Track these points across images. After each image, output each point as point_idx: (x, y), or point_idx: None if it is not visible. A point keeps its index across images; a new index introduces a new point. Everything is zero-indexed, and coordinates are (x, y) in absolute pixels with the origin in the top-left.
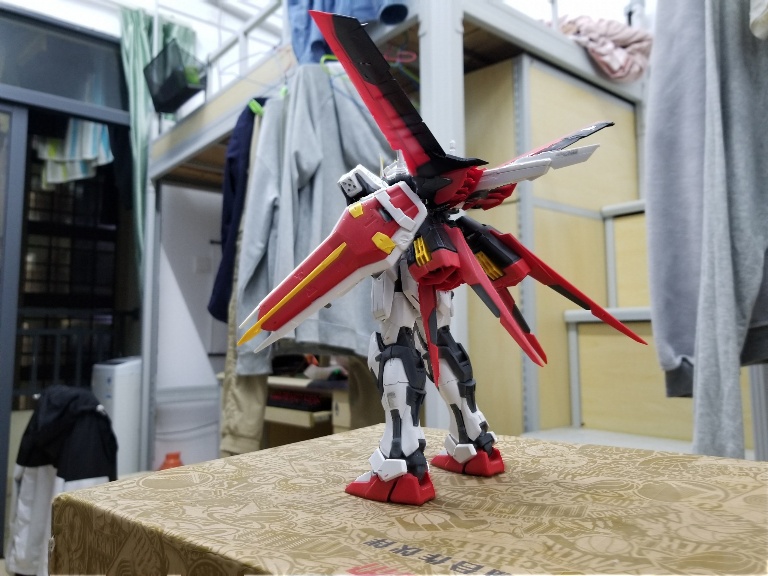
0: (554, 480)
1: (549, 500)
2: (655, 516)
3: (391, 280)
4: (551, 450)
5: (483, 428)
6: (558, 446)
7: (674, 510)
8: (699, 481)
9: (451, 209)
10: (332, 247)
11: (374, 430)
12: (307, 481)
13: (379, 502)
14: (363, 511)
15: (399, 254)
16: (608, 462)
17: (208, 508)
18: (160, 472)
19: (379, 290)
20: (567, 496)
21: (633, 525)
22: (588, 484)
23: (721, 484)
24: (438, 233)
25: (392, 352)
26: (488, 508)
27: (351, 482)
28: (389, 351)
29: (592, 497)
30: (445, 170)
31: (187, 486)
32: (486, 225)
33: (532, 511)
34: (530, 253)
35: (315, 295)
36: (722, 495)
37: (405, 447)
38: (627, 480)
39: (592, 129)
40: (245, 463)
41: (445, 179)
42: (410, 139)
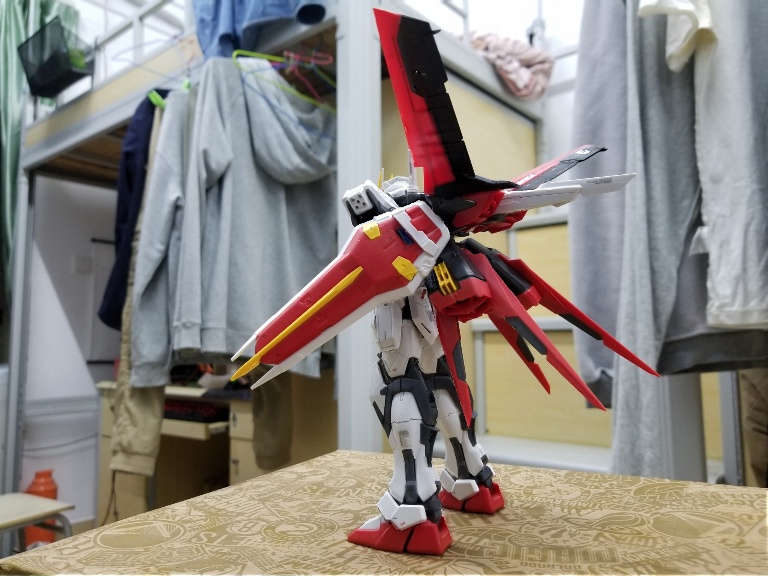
0: (561, 516)
1: (572, 541)
2: (690, 557)
3: (398, 306)
4: (537, 479)
5: (484, 462)
6: (542, 474)
7: (703, 549)
8: (704, 512)
9: (463, 232)
10: (345, 271)
11: (336, 458)
12: (296, 528)
13: (393, 553)
14: (383, 567)
15: (420, 281)
16: (602, 492)
17: (201, 573)
18: (116, 524)
19: (386, 317)
20: (586, 536)
21: (676, 570)
22: (598, 519)
23: (726, 515)
24: (464, 259)
25: (402, 386)
26: (515, 555)
27: (348, 527)
28: (398, 384)
29: (612, 536)
30: (469, 191)
31: (158, 542)
32: (493, 249)
33: (563, 557)
34: (542, 280)
35: (326, 324)
36: (736, 528)
37: (422, 491)
38: (634, 513)
39: (588, 154)
40: (212, 507)
41: (468, 201)
42: (440, 157)
